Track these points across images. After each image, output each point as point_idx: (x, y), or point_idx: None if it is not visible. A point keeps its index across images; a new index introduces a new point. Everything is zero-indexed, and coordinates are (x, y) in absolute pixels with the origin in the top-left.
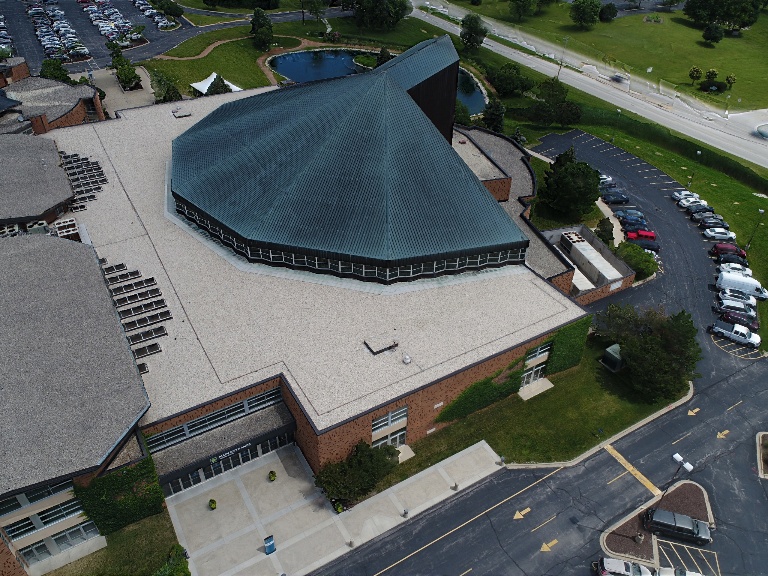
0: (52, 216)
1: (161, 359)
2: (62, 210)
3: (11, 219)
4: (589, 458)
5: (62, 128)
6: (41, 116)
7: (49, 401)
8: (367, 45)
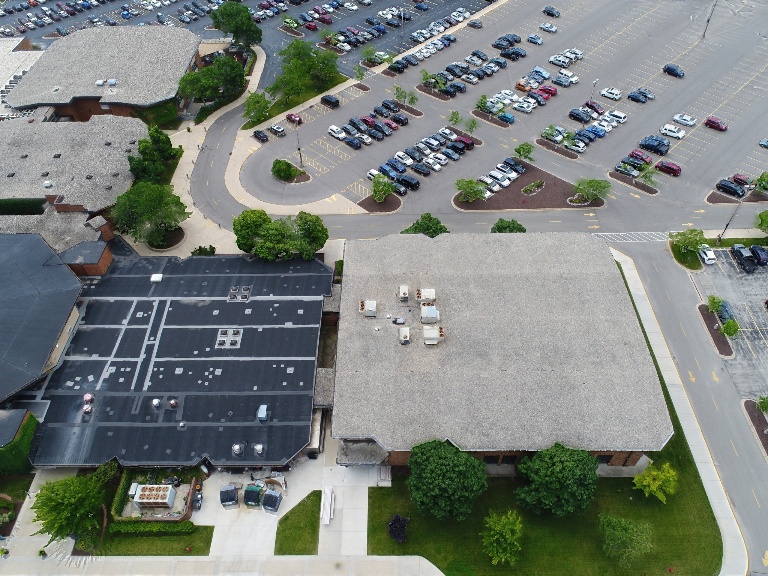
0: None
1: None
2: None
3: None
4: None
5: None
6: None
7: None
8: None
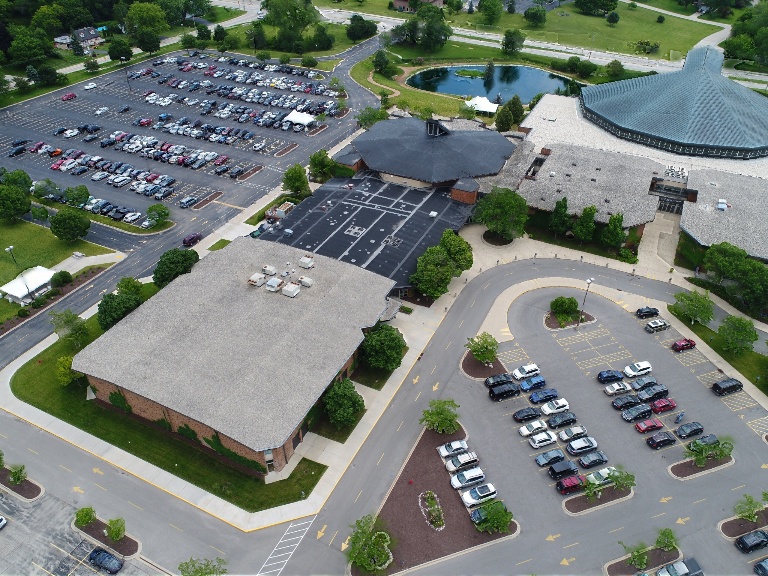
0: None
1: None
2: None
3: None
4: None
5: None
6: None
7: None
8: (444, 63)
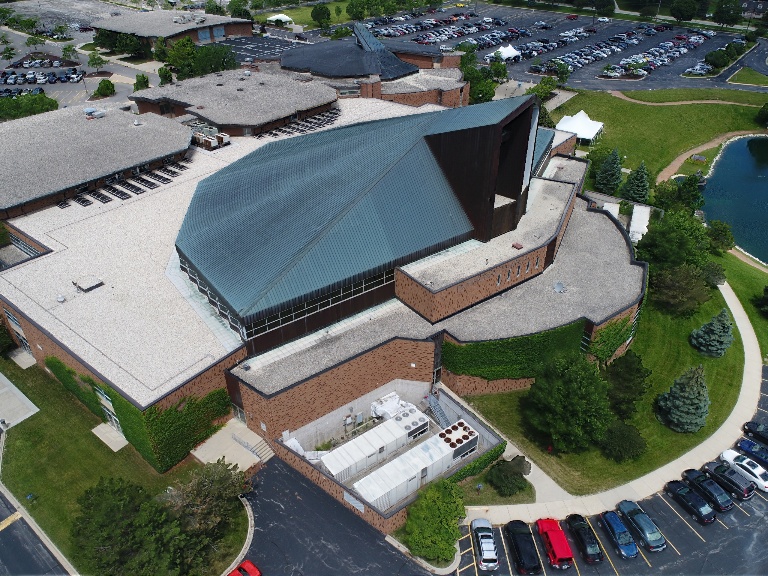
0: (239, 132)
1: (76, 209)
2: (251, 133)
3: (207, 119)
4: (3, 498)
5: (379, 99)
6: (368, 84)
7: (4, 179)
8: None
